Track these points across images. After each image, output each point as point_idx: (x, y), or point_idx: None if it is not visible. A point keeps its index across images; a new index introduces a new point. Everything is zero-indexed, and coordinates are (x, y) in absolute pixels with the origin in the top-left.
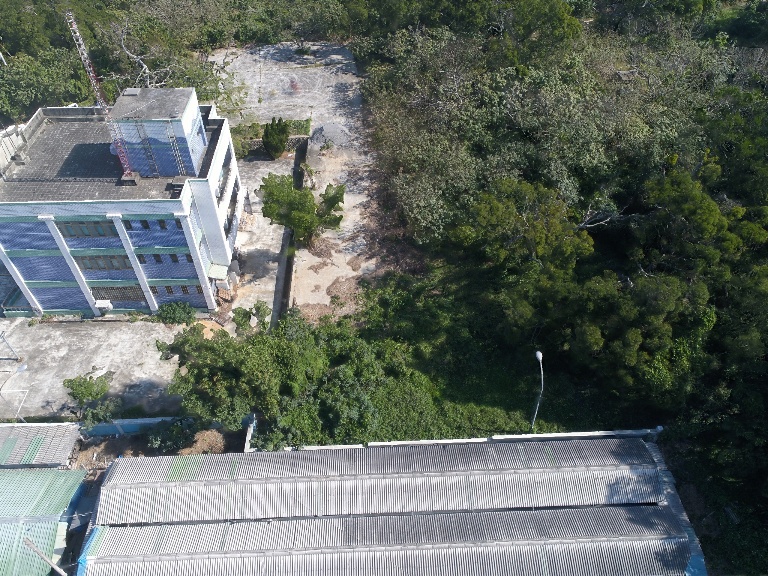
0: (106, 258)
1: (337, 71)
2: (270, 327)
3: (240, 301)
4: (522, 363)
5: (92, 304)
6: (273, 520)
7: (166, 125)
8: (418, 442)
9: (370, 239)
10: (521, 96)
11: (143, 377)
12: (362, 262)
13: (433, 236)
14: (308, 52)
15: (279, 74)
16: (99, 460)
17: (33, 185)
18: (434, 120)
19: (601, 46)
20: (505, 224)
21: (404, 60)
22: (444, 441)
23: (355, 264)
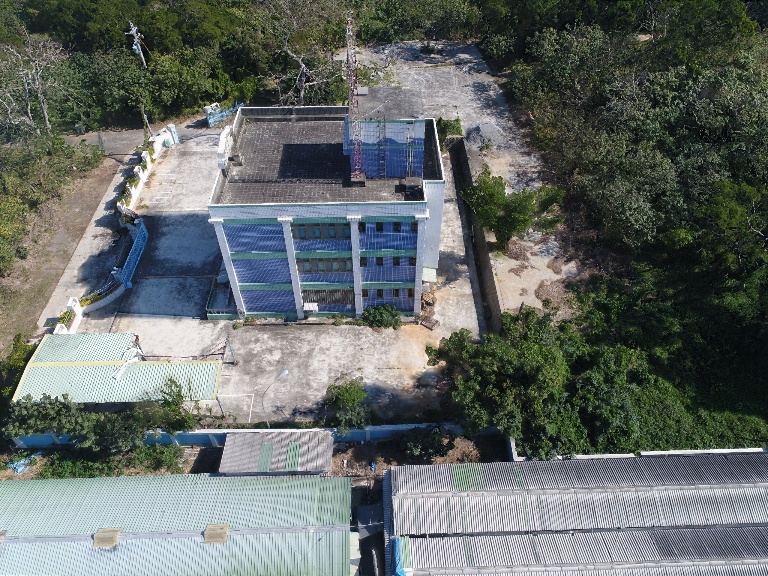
0: (328, 261)
1: (470, 70)
2: (480, 331)
3: (441, 304)
4: (767, 370)
5: (299, 307)
6: (574, 532)
7: (408, 125)
8: (692, 452)
9: (562, 241)
10: (695, 96)
11: (366, 382)
12: (562, 265)
13: (645, 239)
14: (434, 51)
15: (411, 73)
16: (351, 467)
17: (259, 186)
18: (605, 120)
19: (763, 45)
20: (743, 227)
21: (558, 59)
22: (719, 451)
23: (556, 267)
